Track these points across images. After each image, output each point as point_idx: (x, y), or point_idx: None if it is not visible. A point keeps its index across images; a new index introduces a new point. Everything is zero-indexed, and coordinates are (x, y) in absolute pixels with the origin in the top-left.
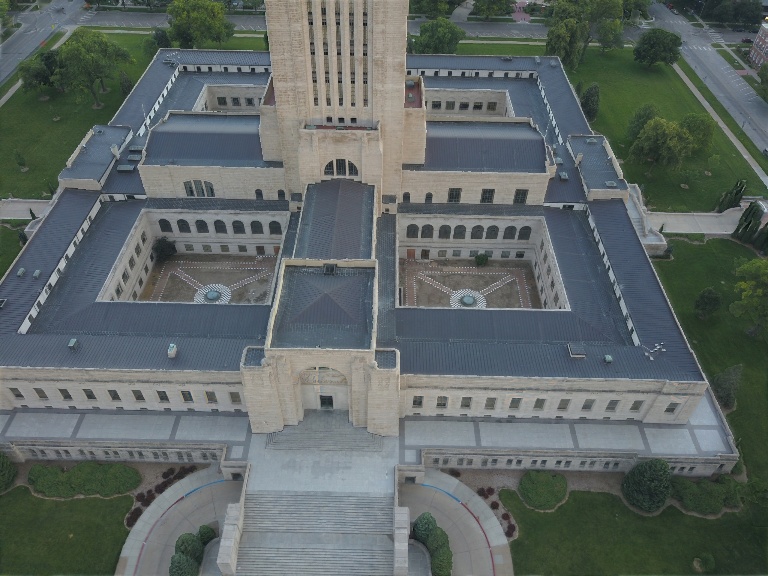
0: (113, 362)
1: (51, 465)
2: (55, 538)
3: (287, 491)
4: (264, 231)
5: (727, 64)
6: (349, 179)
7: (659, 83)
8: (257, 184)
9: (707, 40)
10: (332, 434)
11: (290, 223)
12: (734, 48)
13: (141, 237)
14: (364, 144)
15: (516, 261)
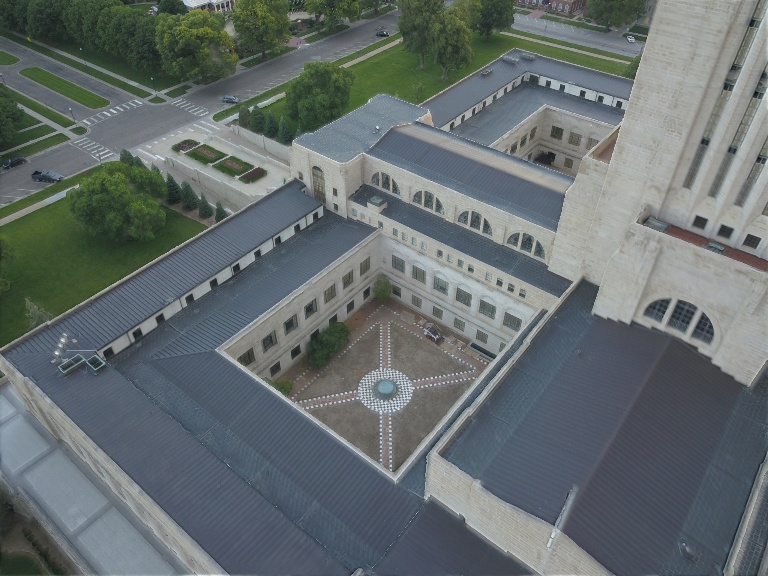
0: None
1: None
2: None
3: None
4: None
5: None
6: None
7: (521, 48)
8: None
9: None
10: None
11: None
12: None
13: None
14: None
15: None
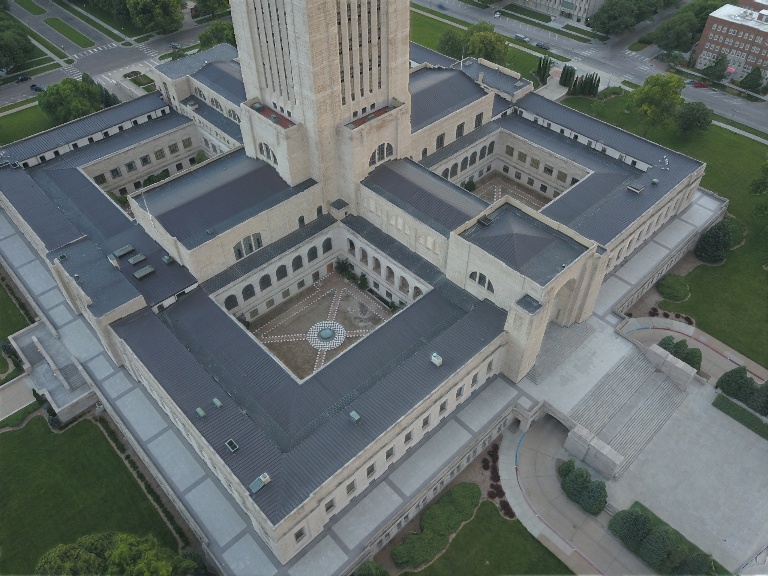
0: (406, 402)
1: (397, 542)
2: (480, 575)
3: (586, 395)
4: (318, 254)
5: None
6: (388, 161)
7: None
8: (300, 211)
9: None
10: (563, 342)
11: (352, 229)
12: None
13: None
14: (399, 121)
15: (487, 175)
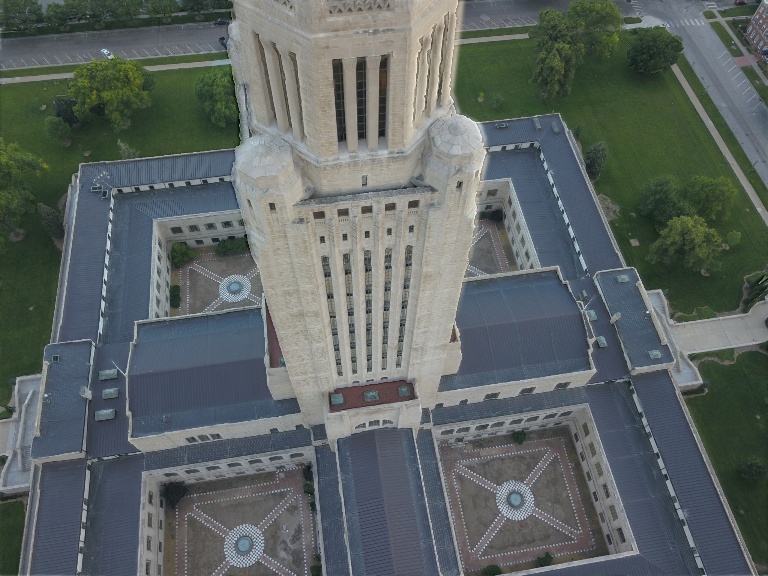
0: None
1: None
2: None
3: None
4: (284, 459)
5: (724, 48)
6: (383, 428)
7: (658, 97)
8: (271, 426)
9: (698, 6)
10: None
11: (318, 465)
12: (729, 19)
13: (148, 501)
14: (403, 412)
15: (553, 427)
